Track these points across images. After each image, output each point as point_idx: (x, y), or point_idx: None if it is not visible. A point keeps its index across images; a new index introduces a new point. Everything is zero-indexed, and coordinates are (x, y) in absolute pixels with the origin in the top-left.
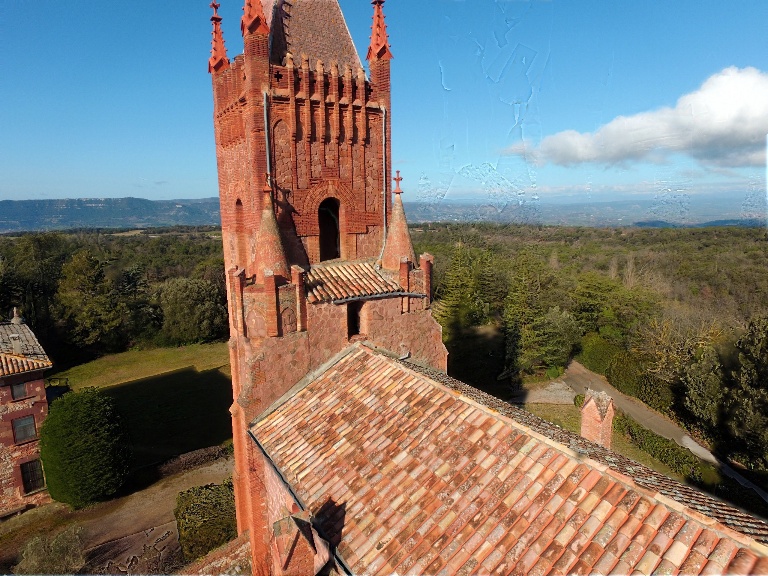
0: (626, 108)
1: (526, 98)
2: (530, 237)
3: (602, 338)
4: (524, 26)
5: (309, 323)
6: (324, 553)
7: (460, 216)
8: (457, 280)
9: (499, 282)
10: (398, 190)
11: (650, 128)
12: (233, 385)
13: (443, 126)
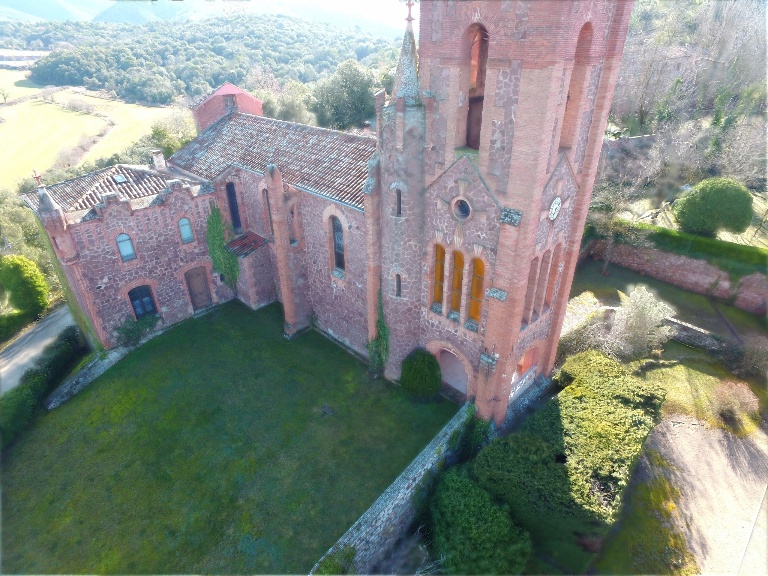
0: None
1: None
2: None
3: None
4: None
5: None
6: None
7: None
8: None
9: None
10: (409, 18)
11: None
12: None
13: None
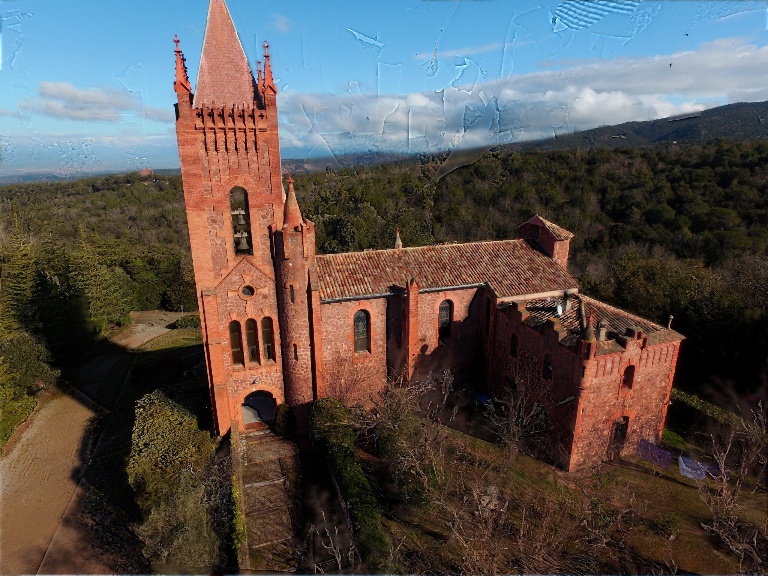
0: (78, 81)
1: None
2: (47, 206)
3: (141, 283)
4: None
5: None
6: (383, 311)
7: (23, 189)
8: (25, 259)
9: None
10: None
11: (107, 104)
12: (209, 324)
13: None
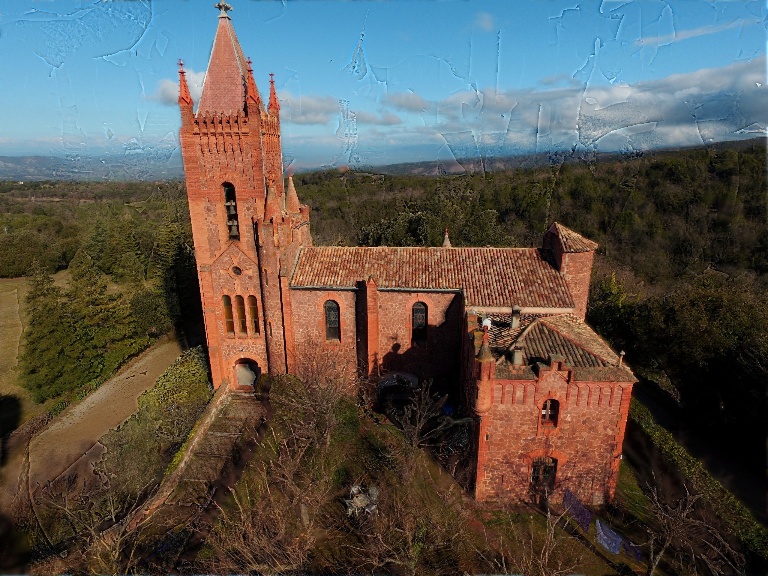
0: None
1: (163, 73)
2: None
3: None
4: (169, 17)
5: (293, 238)
6: (352, 304)
7: (170, 181)
8: (171, 234)
9: (187, 234)
10: None
11: None
12: (206, 295)
13: (60, 83)
